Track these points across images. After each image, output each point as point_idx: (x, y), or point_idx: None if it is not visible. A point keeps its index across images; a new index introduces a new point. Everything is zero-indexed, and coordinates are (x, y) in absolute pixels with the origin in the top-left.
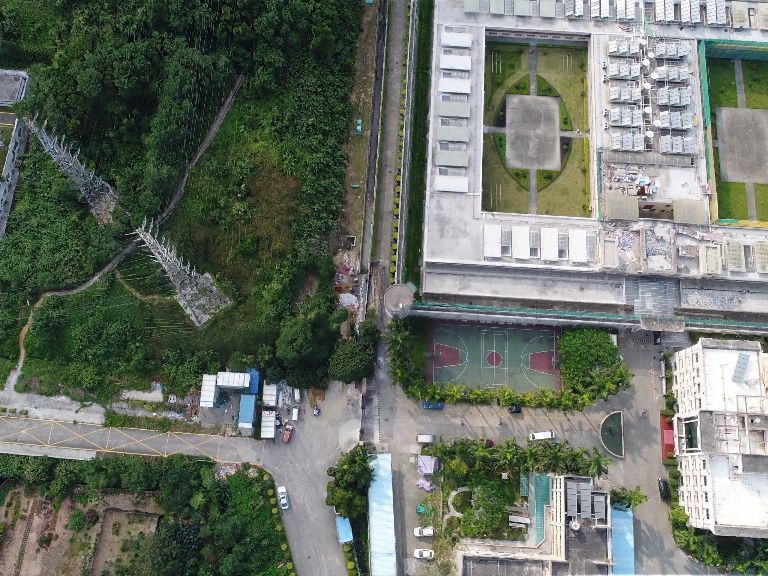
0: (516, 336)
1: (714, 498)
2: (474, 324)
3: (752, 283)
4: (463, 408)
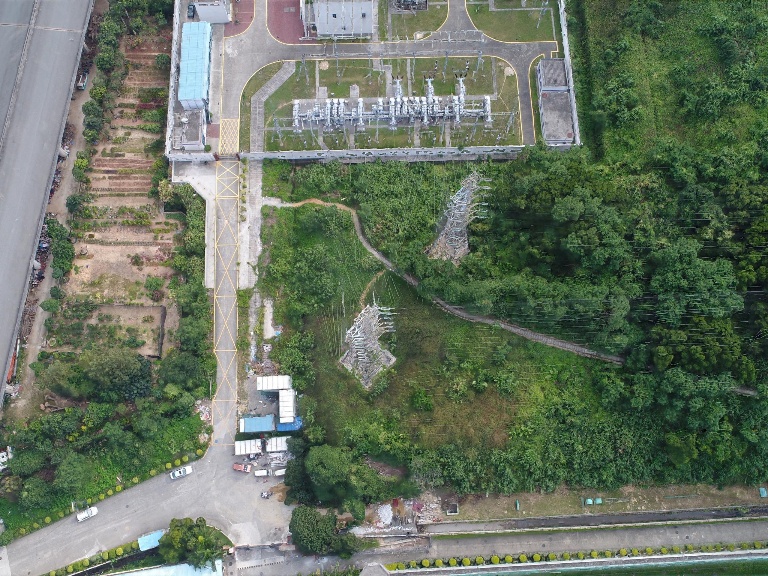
0: None
1: None
2: None
3: None
4: None
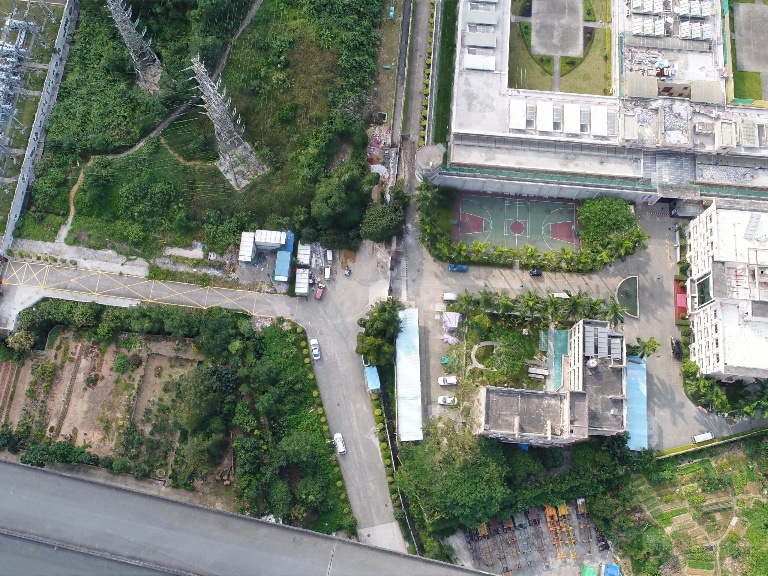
0: (538, 207)
1: (724, 342)
2: (498, 196)
3: (765, 160)
4: (486, 271)
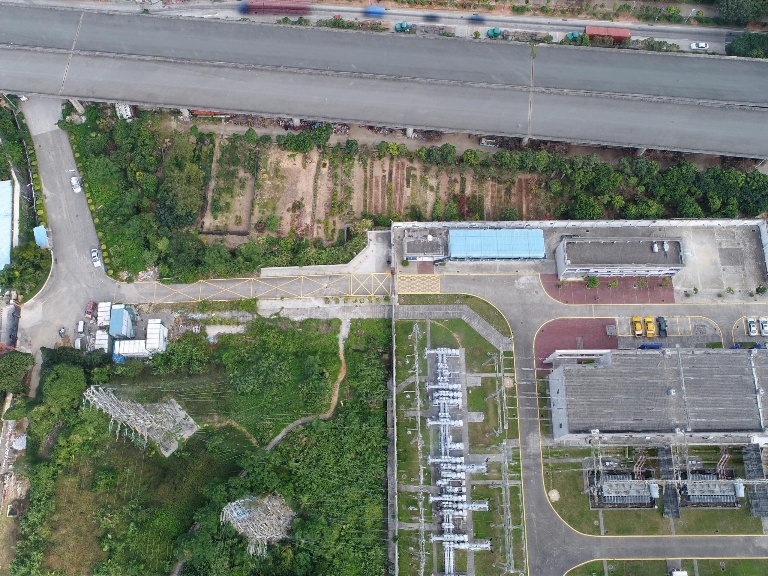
0: None
1: None
2: None
3: None
4: None
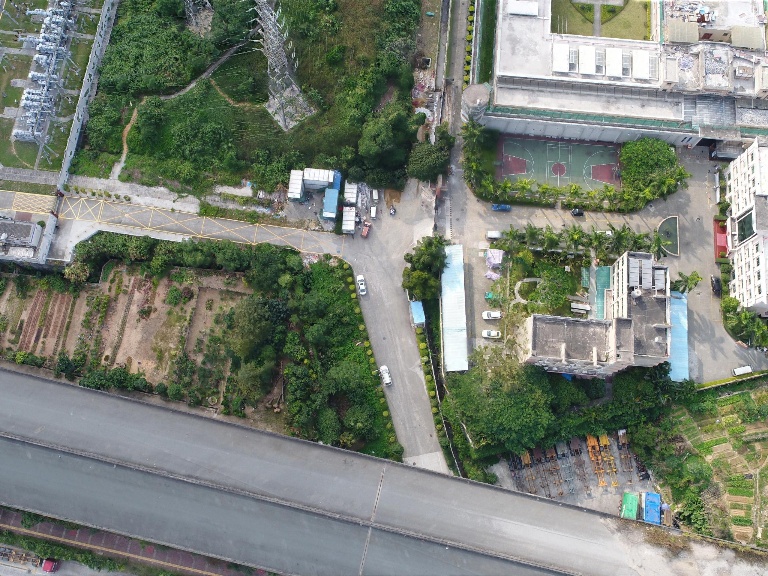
0: (579, 150)
1: (766, 274)
2: (540, 138)
3: None
4: (529, 211)
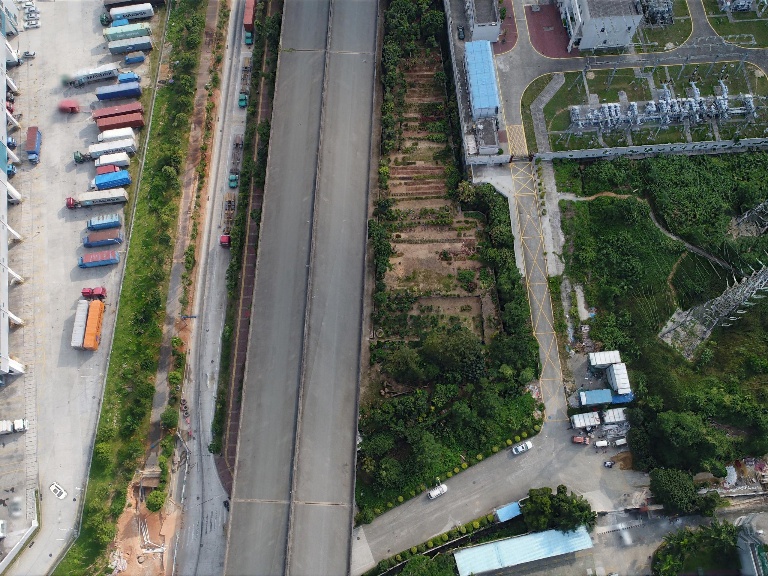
0: None
1: None
2: None
3: None
4: None
